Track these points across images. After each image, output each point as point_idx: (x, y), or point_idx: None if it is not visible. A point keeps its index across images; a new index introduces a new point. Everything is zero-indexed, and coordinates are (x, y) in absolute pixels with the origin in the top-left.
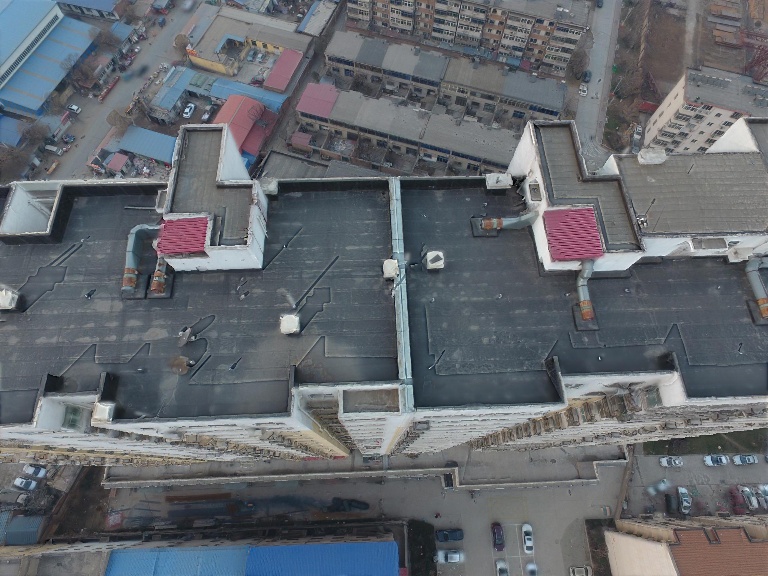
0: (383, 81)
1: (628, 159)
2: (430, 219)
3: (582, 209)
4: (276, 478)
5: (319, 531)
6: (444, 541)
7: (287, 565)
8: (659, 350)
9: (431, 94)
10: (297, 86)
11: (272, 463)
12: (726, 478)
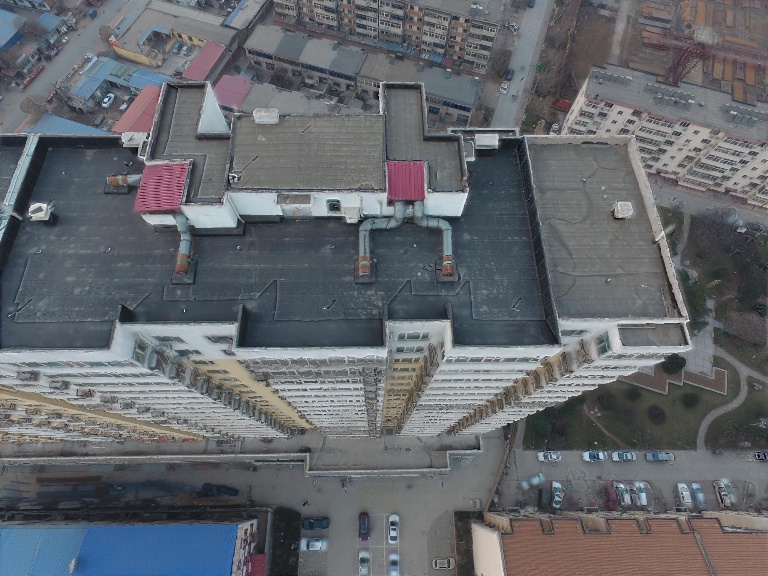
0: (303, 75)
1: (247, 118)
2: (70, 176)
3: (179, 164)
4: (127, 459)
5: (184, 516)
6: (309, 529)
7: (122, 545)
8: (250, 305)
9: (351, 89)
10: (218, 78)
11: (125, 444)
12: (603, 474)
